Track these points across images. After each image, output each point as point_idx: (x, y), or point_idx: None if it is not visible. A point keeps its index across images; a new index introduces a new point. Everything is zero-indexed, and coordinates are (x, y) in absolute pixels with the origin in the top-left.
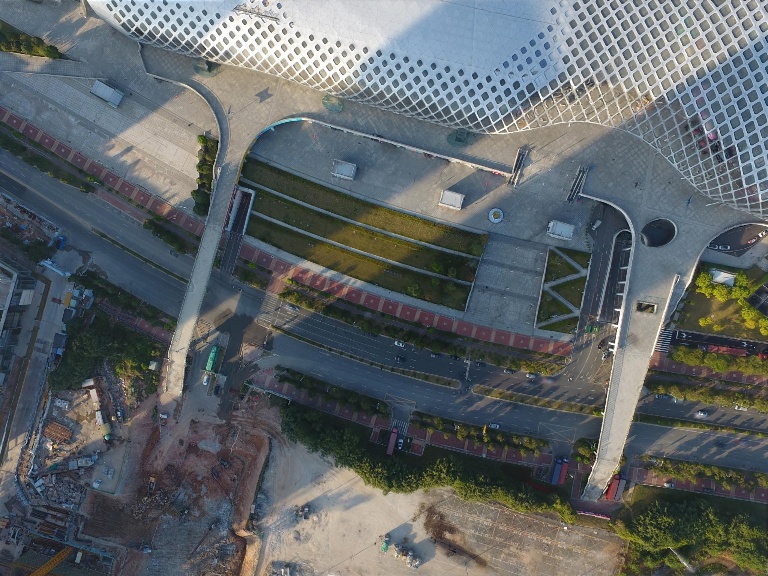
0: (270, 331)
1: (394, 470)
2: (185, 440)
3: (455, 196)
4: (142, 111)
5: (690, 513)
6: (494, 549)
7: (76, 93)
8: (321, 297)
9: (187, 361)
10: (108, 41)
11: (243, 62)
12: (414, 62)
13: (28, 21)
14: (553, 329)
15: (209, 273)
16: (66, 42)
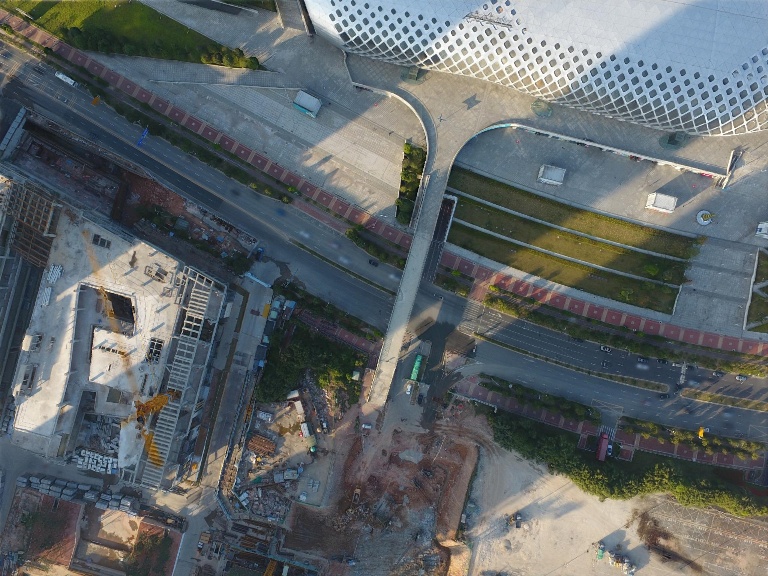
0: (473, 339)
1: (613, 476)
2: (388, 450)
3: (668, 199)
4: (341, 120)
5: None
6: (709, 554)
7: (273, 104)
8: (524, 303)
9: None
10: (306, 51)
11: (463, 69)
12: (649, 66)
13: (224, 33)
14: (762, 331)
15: (419, 281)
16: (263, 53)
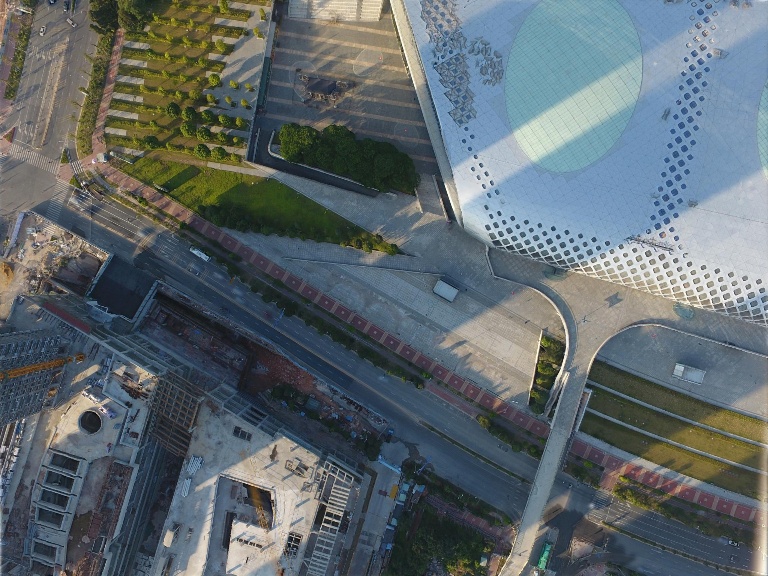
0: (601, 527)
1: None
2: None
3: None
4: (476, 306)
5: None
6: None
7: (408, 287)
8: (653, 494)
9: None
10: (444, 236)
11: (614, 279)
12: None
13: (362, 214)
14: None
15: (554, 477)
16: (400, 236)
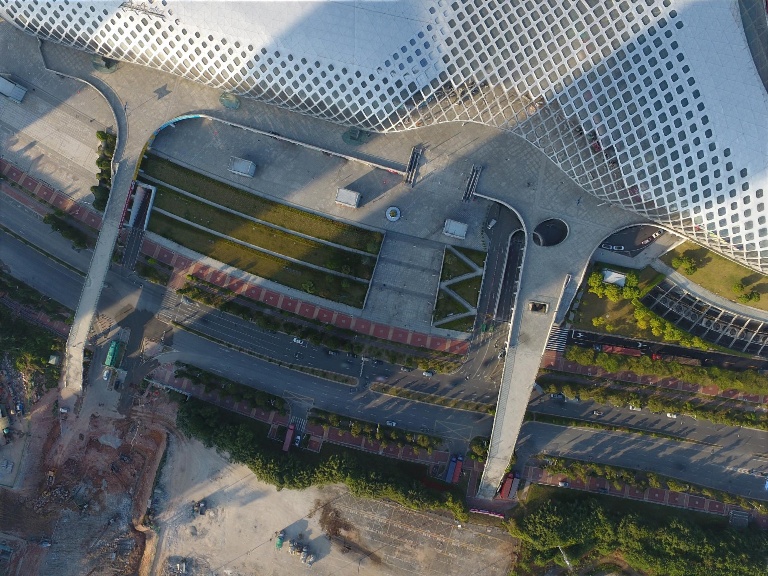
0: (170, 327)
1: (286, 466)
2: (85, 434)
3: (350, 194)
4: (45, 106)
5: (580, 512)
6: (389, 546)
7: None
8: (221, 293)
9: (87, 356)
10: (12, 37)
11: (135, 58)
12: (298, 60)
13: None
14: (450, 327)
15: (106, 268)
16: None
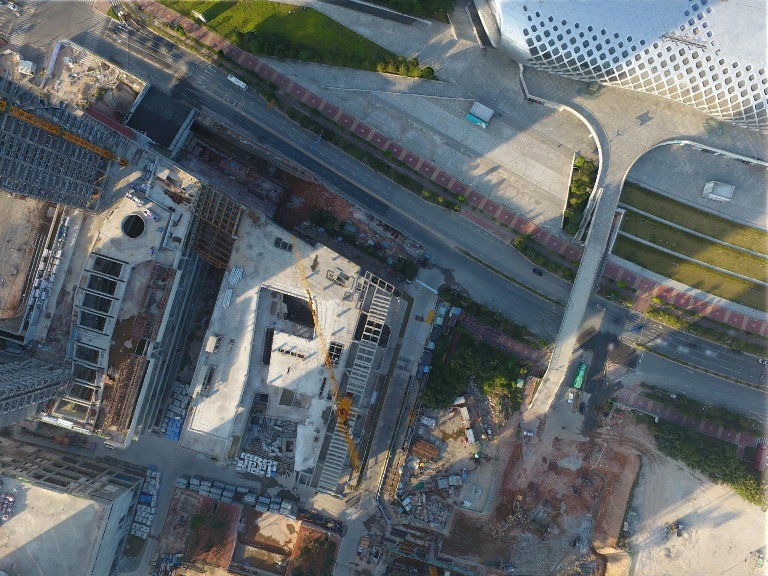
0: (634, 349)
1: None
2: (548, 458)
3: None
4: (510, 132)
5: None
6: None
7: (443, 113)
8: (685, 315)
9: None
10: (478, 63)
11: (647, 87)
12: None
13: (397, 42)
14: None
15: None
16: (435, 63)
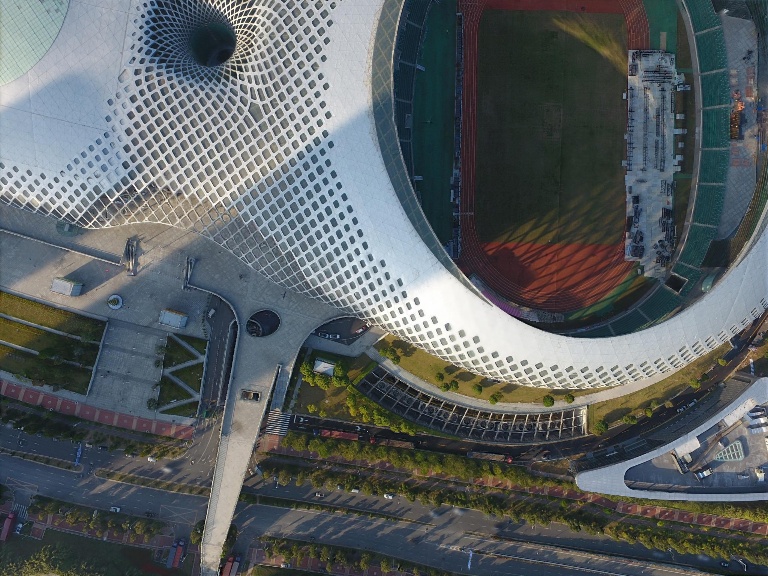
0: None
1: None
2: None
3: (64, 284)
4: None
5: None
6: None
7: None
8: None
9: None
10: None
11: None
12: None
13: None
14: (174, 413)
15: None
16: None
